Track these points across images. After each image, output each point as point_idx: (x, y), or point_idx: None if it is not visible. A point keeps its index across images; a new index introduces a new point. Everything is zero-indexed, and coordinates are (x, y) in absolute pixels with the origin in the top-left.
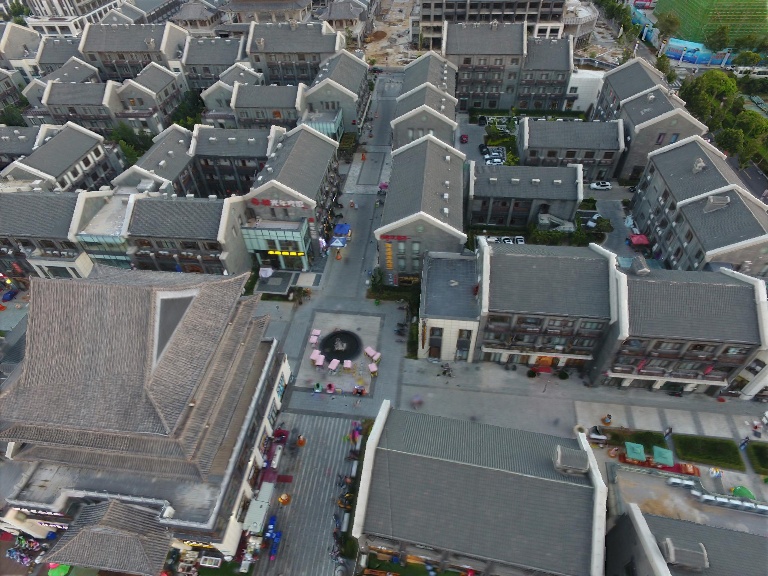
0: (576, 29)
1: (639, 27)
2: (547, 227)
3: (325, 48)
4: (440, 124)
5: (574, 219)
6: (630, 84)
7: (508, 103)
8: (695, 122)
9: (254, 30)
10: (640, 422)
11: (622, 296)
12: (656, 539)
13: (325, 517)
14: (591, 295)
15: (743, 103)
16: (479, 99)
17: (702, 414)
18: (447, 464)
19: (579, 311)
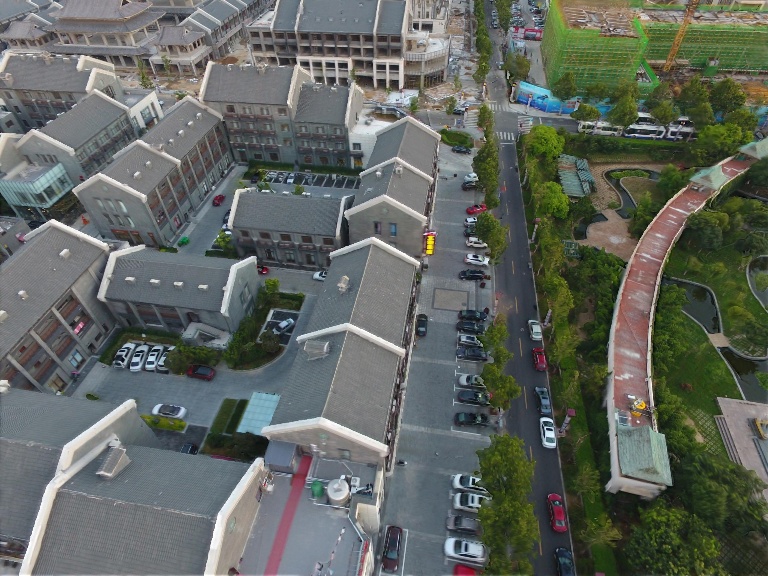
0: (421, 66)
1: (485, 67)
2: (192, 342)
3: (78, 87)
4: (125, 195)
5: (233, 331)
6: (384, 150)
7: (290, 157)
8: (408, 212)
9: (8, 62)
10: None
11: (36, 520)
12: None
13: None
14: (28, 504)
15: (553, 170)
16: (258, 151)
17: None
18: None
19: (4, 528)
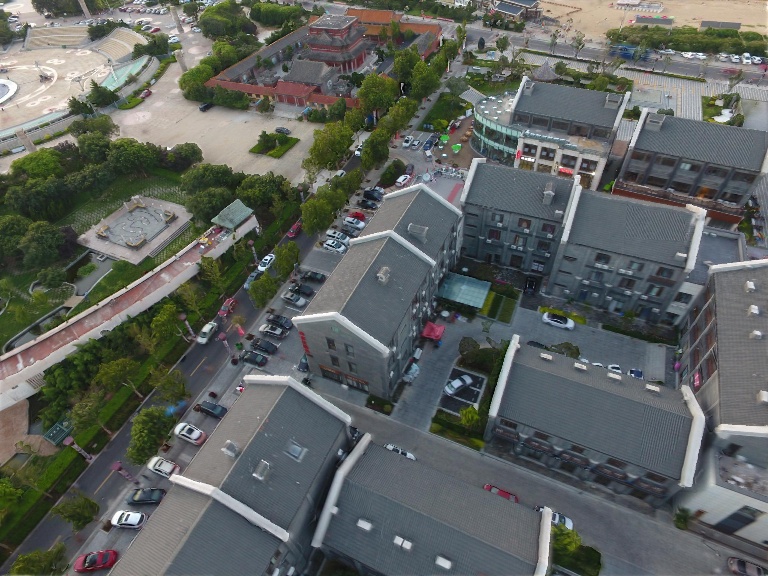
0: None
1: None
2: None
3: None
4: None
5: None
6: None
7: None
8: None
9: None
10: None
11: None
12: None
13: (765, 208)
14: None
15: None
16: None
17: None
18: None
19: None
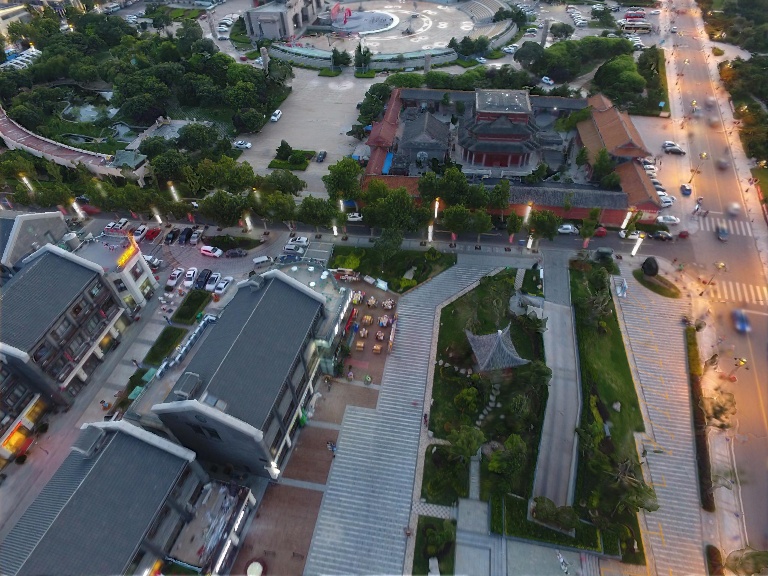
0: None
1: None
2: None
3: None
4: None
5: None
6: None
7: None
8: None
9: None
10: (122, 381)
11: None
12: (175, 401)
13: None
14: None
15: None
16: None
17: (140, 336)
18: (22, 572)
19: None
